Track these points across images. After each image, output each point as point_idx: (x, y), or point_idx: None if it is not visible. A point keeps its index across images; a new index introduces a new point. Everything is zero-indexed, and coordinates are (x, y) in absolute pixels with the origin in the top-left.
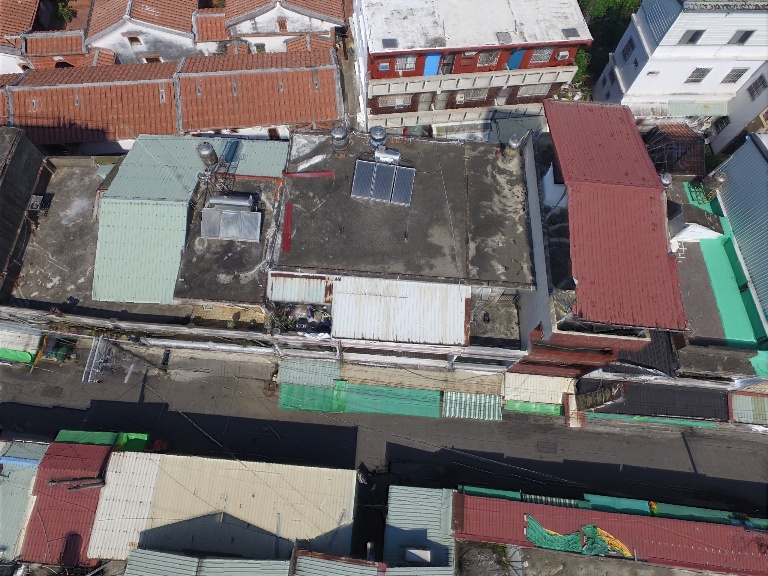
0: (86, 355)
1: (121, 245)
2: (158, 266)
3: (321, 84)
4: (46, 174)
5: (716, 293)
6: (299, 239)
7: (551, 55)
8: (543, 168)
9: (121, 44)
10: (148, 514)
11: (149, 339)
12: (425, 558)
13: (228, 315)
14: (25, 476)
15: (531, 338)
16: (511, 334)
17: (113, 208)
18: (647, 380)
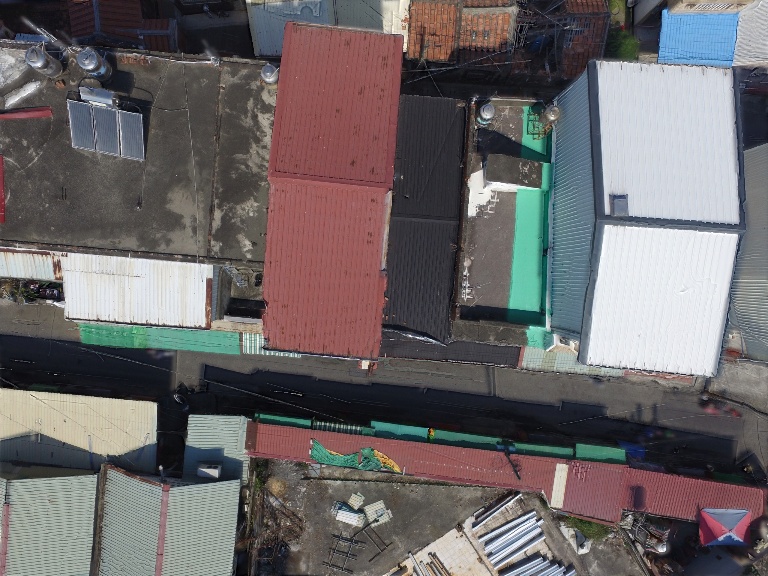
0: None
1: None
2: None
3: None
4: None
5: (515, 256)
6: (14, 205)
7: None
8: None
9: None
10: None
11: None
12: (214, 475)
13: None
14: None
15: None
16: None
17: None
18: None
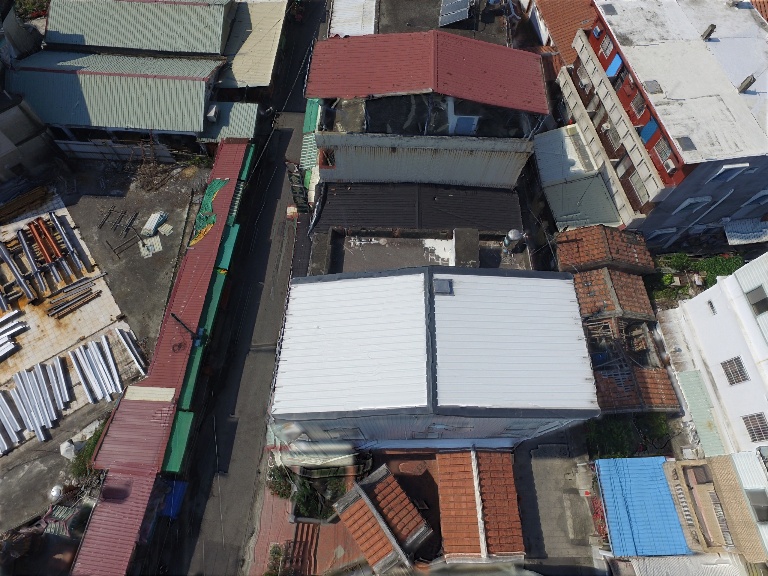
0: None
1: None
2: None
3: None
4: None
5: None
6: None
7: None
8: None
9: None
10: (255, 3)
11: None
12: (210, 114)
13: None
14: None
15: None
16: None
17: None
18: None
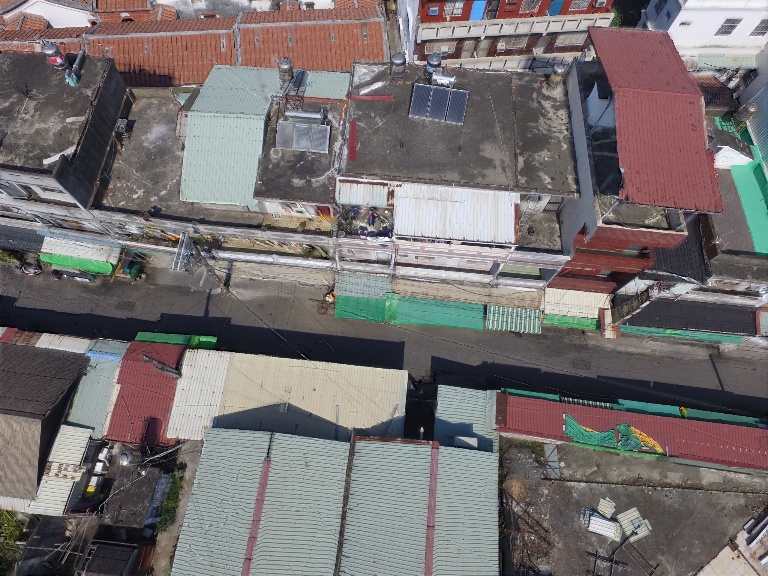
0: (155, 275)
1: (205, 153)
2: (238, 172)
3: (369, 36)
4: (128, 103)
5: (746, 213)
6: (363, 151)
7: (589, 3)
8: (585, 94)
9: (183, 1)
10: (220, 402)
11: (219, 251)
12: (473, 444)
13: (295, 224)
14: (110, 367)
15: (574, 244)
16: (554, 245)
17: (198, 120)
18: (679, 295)
